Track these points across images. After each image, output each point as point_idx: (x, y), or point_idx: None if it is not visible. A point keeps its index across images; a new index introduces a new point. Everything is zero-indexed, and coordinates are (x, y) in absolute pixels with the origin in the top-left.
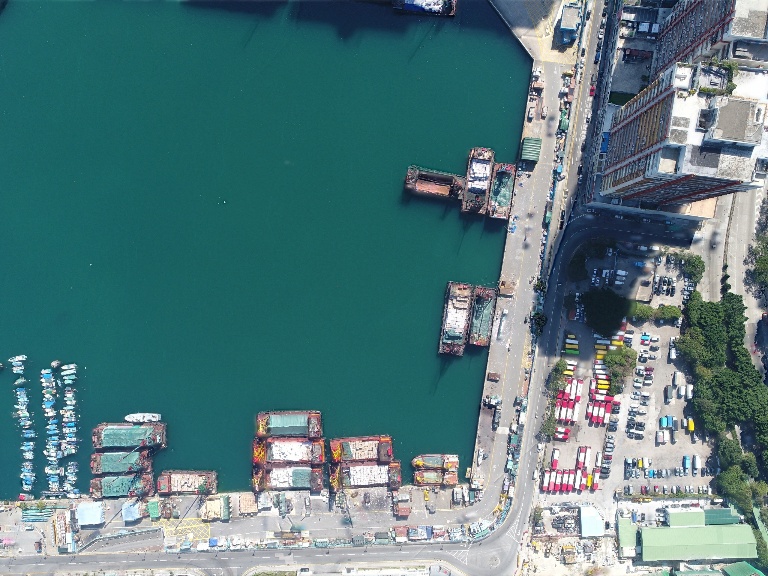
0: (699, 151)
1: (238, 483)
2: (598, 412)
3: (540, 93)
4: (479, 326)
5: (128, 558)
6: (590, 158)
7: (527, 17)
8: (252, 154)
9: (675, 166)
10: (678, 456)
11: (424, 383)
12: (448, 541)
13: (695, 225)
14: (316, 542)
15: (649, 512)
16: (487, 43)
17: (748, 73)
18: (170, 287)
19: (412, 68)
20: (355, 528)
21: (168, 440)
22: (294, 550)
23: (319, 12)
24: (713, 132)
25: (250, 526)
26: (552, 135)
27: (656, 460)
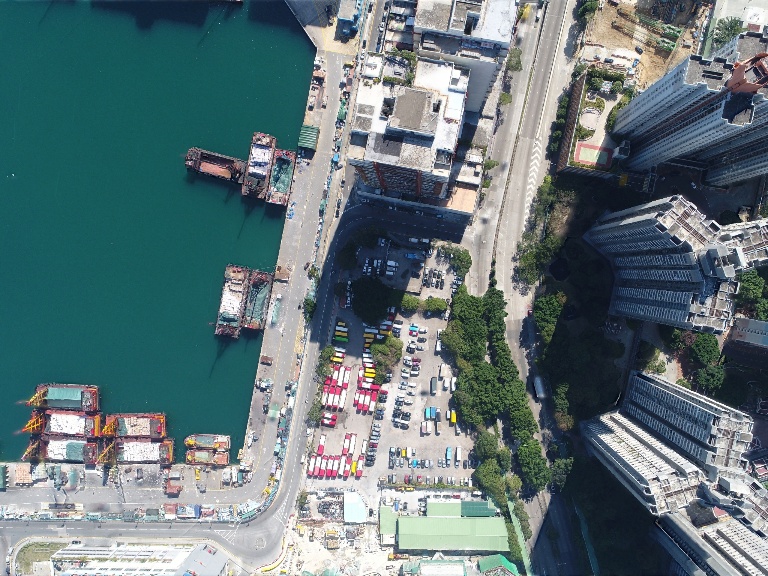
0: (382, 139)
1: (16, 453)
2: (364, 400)
3: (322, 82)
4: (252, 309)
5: None
6: None
7: (312, 7)
8: (43, 129)
9: (364, 153)
10: (442, 447)
11: (202, 363)
12: (216, 521)
13: (466, 220)
14: (87, 515)
15: (412, 501)
16: (274, 30)
17: (431, 65)
18: None
19: (201, 52)
20: (127, 503)
21: None
22: (67, 522)
23: None
24: (389, 120)
25: (26, 496)
26: (332, 124)
27: (420, 450)
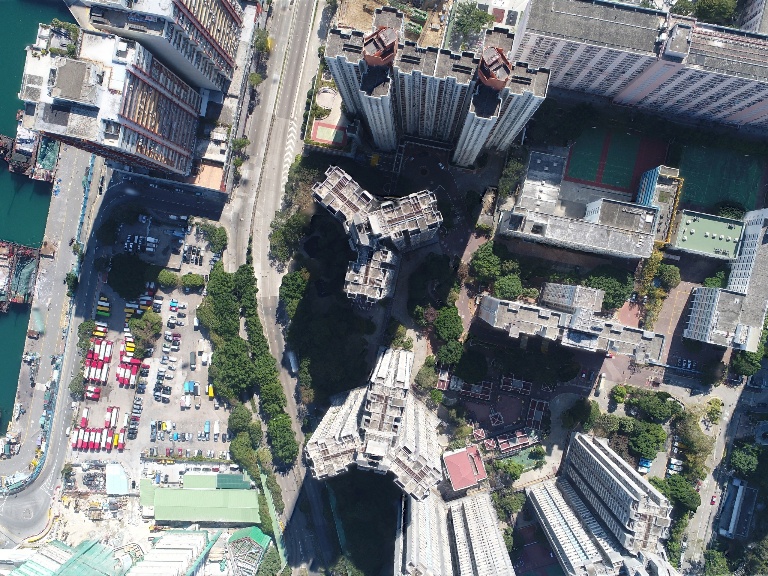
0: (51, 109)
1: None
2: (124, 373)
3: None
4: (17, 284)
5: None
6: None
7: None
8: None
9: None
10: (202, 421)
11: None
12: None
13: (224, 198)
14: None
15: (173, 474)
16: (43, 11)
17: (96, 37)
18: None
19: None
20: None
21: None
22: None
23: None
24: None
25: None
26: None
27: (181, 424)
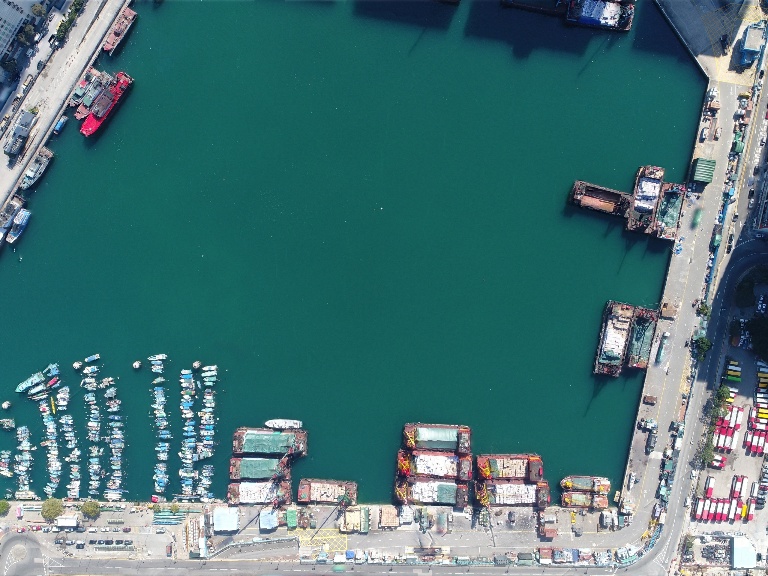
0: None
1: (379, 495)
2: (758, 441)
3: (714, 114)
4: (639, 348)
5: (261, 566)
6: (765, 182)
7: (705, 36)
8: (412, 161)
9: None
10: None
11: (576, 403)
12: (593, 565)
13: None
14: (458, 560)
15: None
16: (661, 60)
17: None
18: (319, 292)
19: (582, 82)
20: (497, 547)
21: (308, 448)
22: (433, 567)
23: (488, 20)
24: None
25: (389, 540)
26: (724, 157)
27: None
